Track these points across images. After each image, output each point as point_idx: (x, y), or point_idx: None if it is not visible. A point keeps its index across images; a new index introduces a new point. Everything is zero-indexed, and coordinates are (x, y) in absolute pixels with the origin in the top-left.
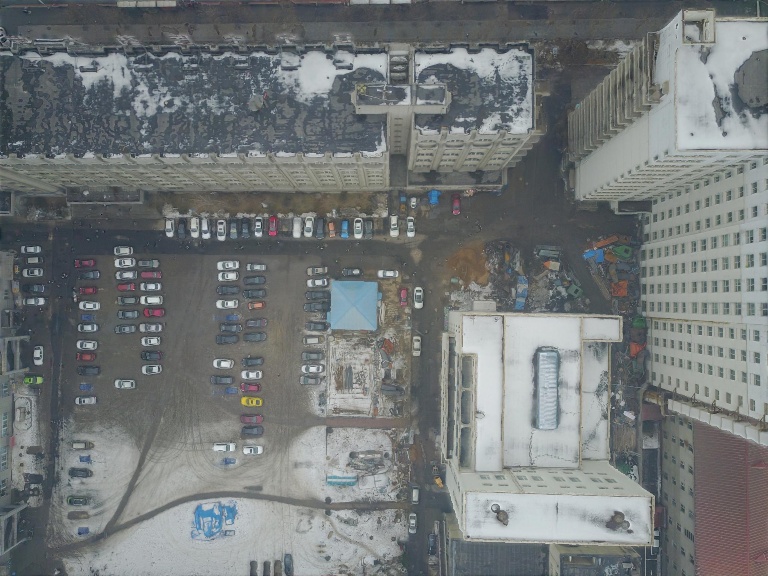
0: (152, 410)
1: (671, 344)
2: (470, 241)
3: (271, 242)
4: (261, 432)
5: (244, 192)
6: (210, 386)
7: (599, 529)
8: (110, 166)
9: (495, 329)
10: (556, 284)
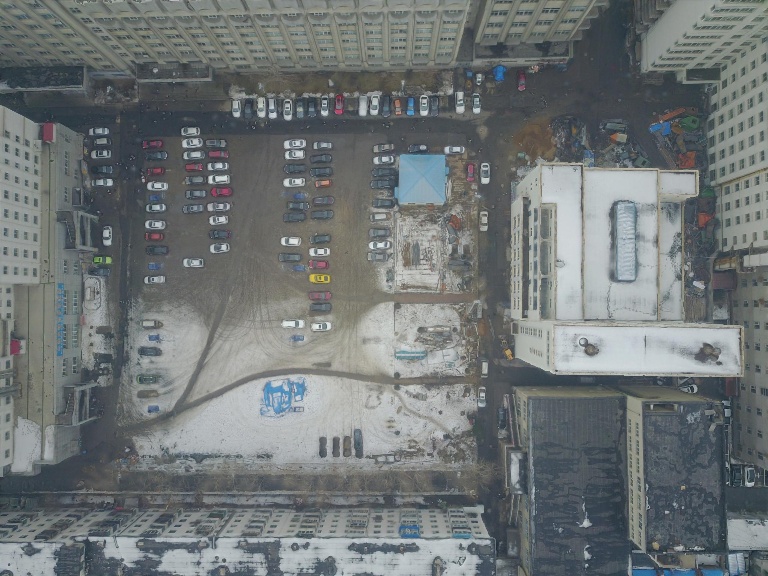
0: (220, 289)
1: (746, 201)
2: (536, 117)
3: (337, 121)
4: (329, 308)
5: (310, 72)
6: (278, 264)
7: (688, 361)
8: (191, 19)
9: (574, 179)
10: (623, 157)
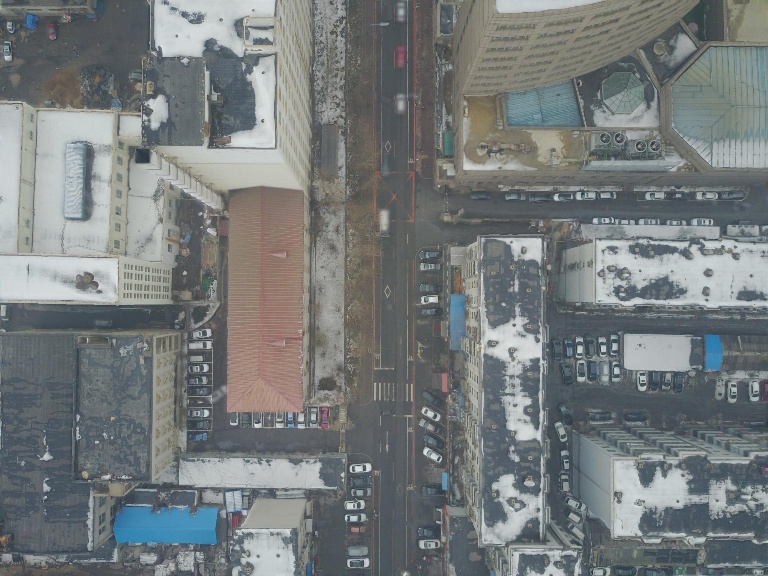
0: None
1: None
2: (67, 66)
3: None
4: None
5: None
6: None
7: (69, 289)
8: None
9: (16, 117)
10: None
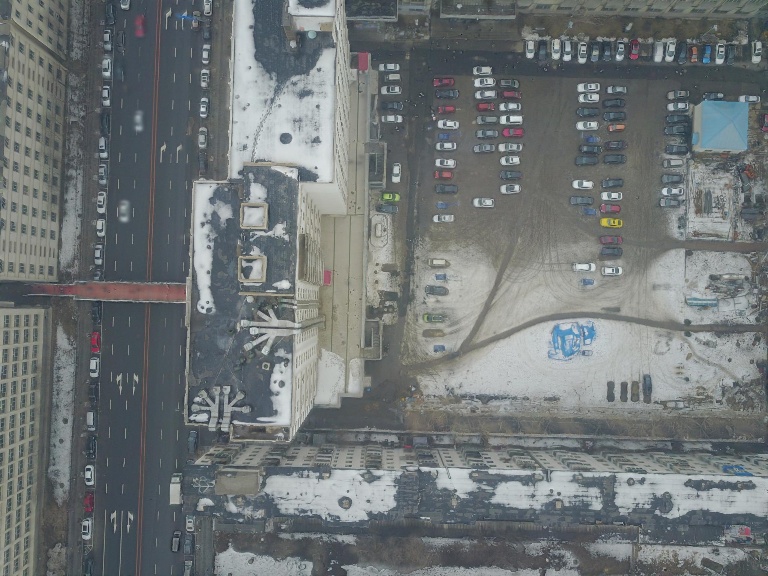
0: (509, 230)
1: None
2: None
3: (630, 66)
4: (621, 253)
5: None
6: (568, 207)
7: None
8: None
9: None
10: None
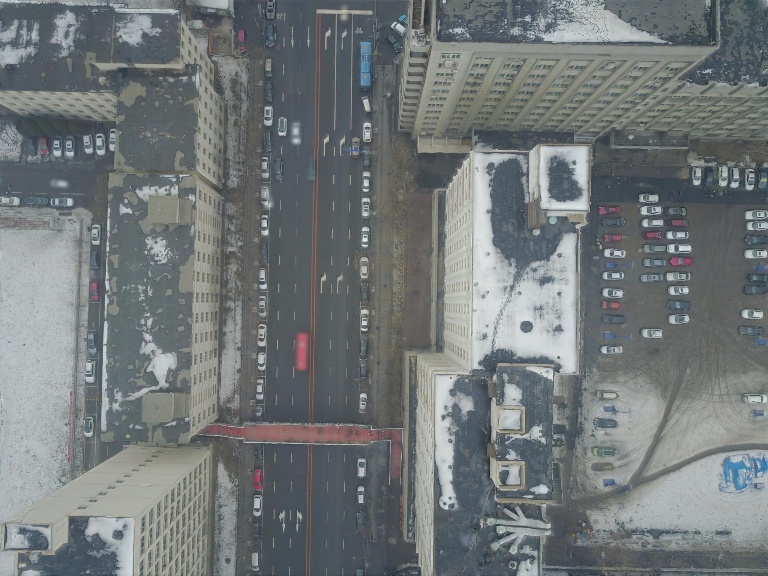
0: (678, 360)
1: None
2: None
3: None
4: None
5: None
6: (737, 337)
7: None
8: (761, 100)
9: None
10: None
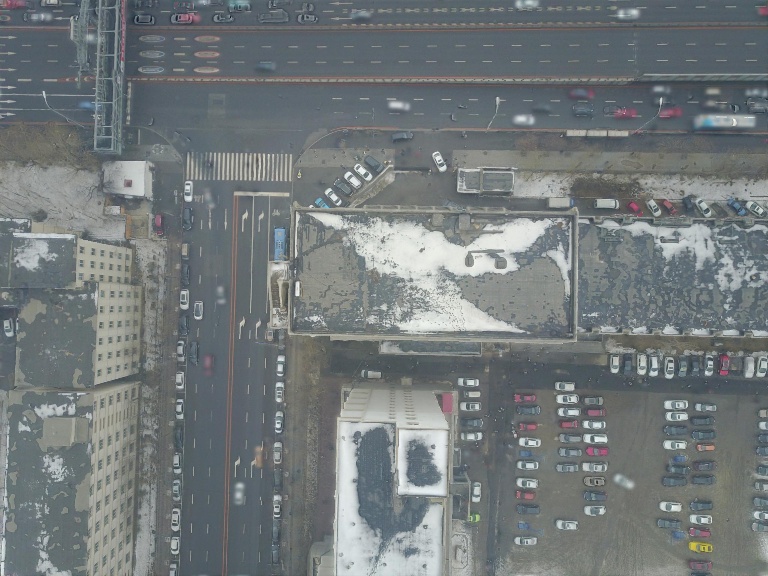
0: (594, 552)
1: None
2: None
3: (719, 381)
4: None
5: None
6: (655, 529)
7: None
8: None
9: None
10: None
